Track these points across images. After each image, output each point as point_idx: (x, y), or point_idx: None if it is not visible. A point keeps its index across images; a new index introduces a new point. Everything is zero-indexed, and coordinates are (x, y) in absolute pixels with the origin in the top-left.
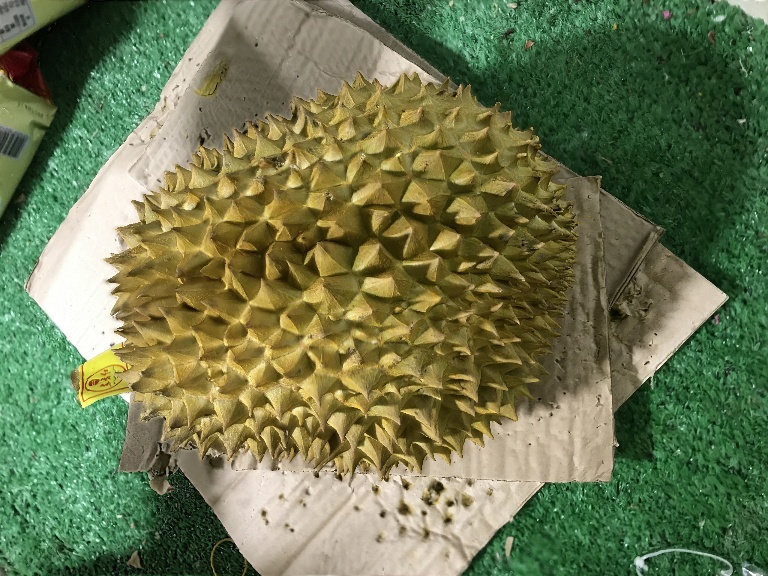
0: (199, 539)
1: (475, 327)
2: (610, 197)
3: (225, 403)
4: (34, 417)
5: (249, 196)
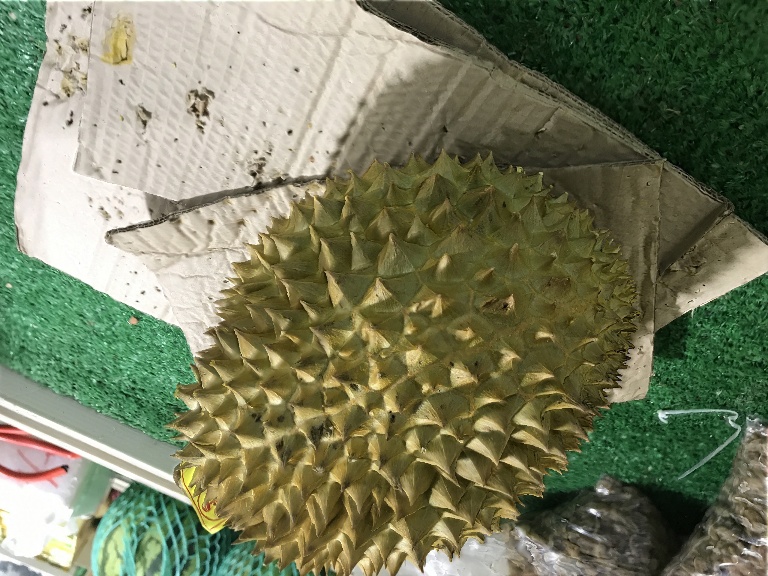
0: None
1: None
2: (673, 174)
3: None
4: (98, 333)
5: (309, 465)
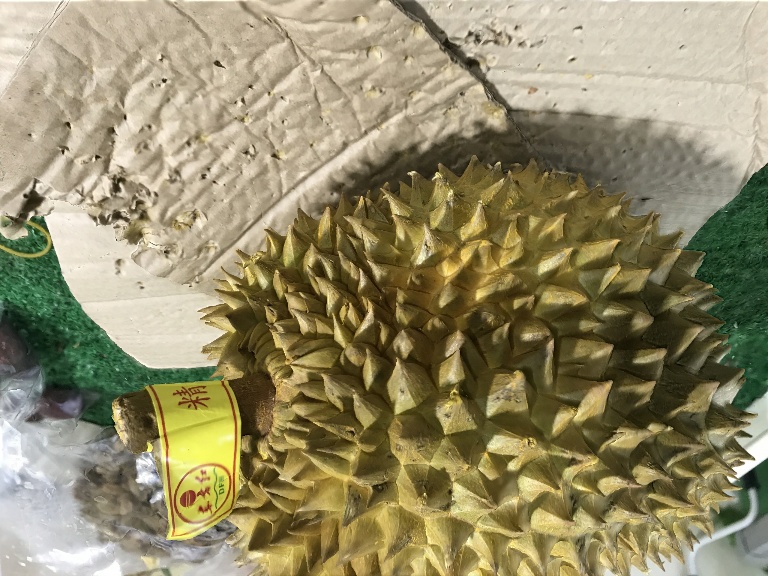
0: None
1: None
2: None
3: None
4: None
5: (564, 561)
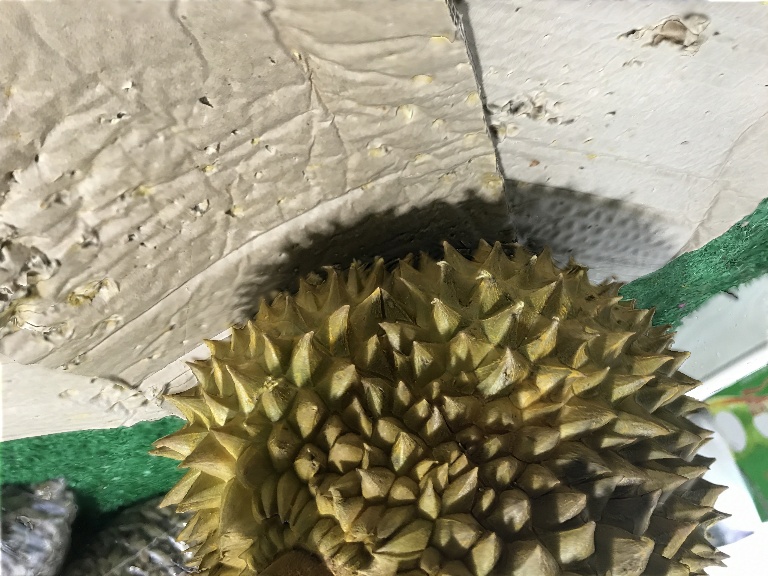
0: None
1: None
2: None
3: None
4: None
5: None
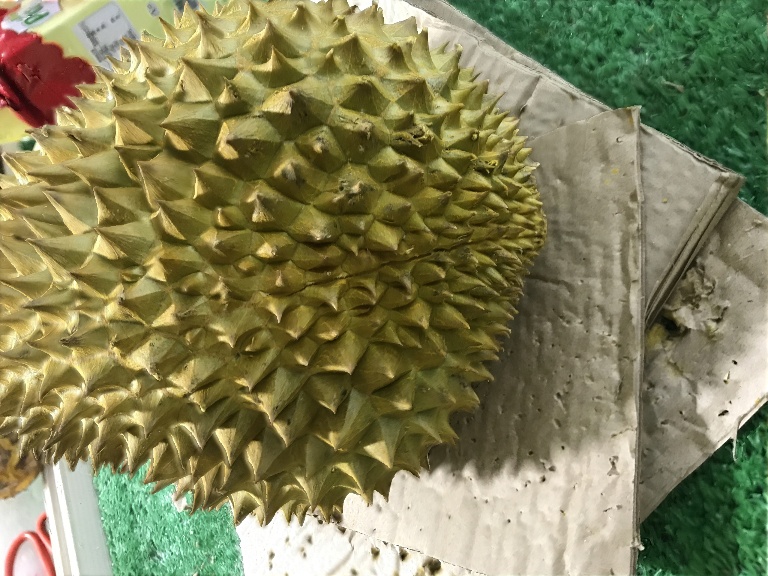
0: (239, 573)
1: (263, 310)
2: (658, 137)
3: (2, 390)
4: None
5: None
